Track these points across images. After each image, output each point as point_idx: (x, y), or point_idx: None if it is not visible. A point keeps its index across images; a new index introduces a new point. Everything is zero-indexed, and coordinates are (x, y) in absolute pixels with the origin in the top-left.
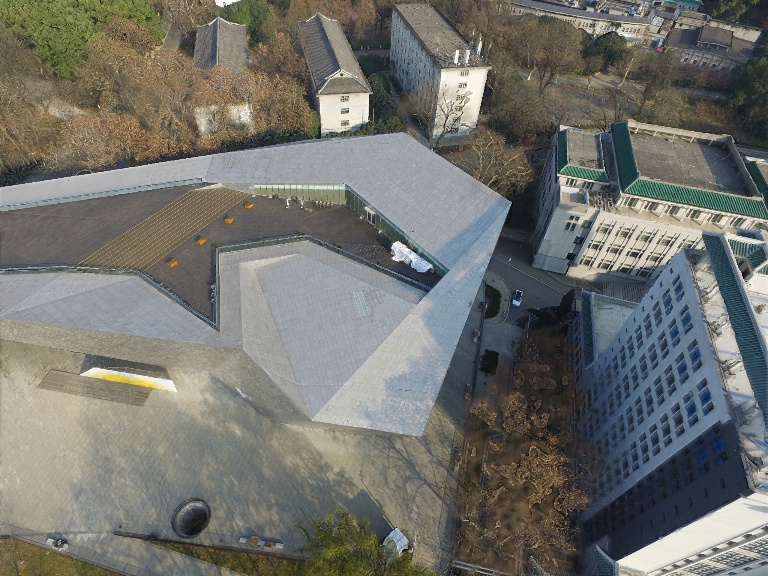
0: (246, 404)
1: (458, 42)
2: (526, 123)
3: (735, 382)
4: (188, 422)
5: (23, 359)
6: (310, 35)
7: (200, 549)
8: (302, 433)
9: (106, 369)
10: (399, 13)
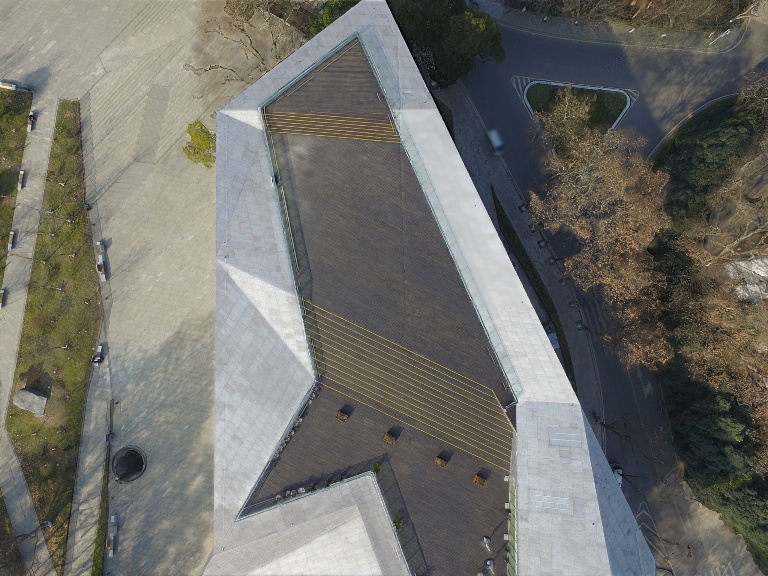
0: None
1: None
2: None
3: None
4: None
5: None
6: None
7: None
8: None
9: None
10: None
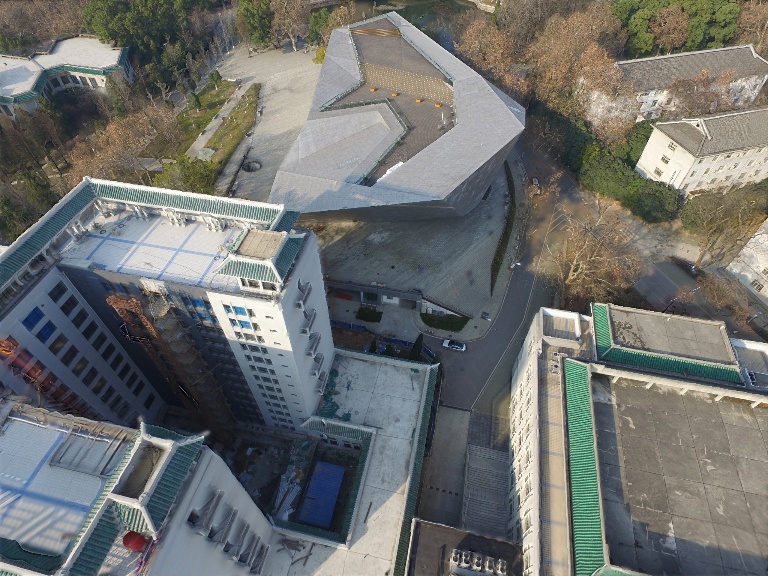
0: None
1: None
2: (715, 282)
3: (168, 225)
4: None
5: None
6: None
7: None
8: None
9: None
10: None
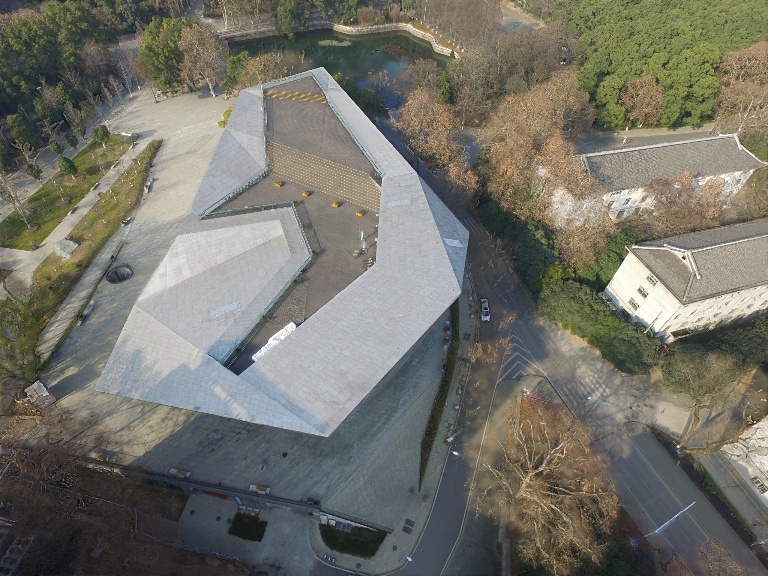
0: None
1: None
2: (726, 568)
3: None
4: None
5: None
6: None
7: None
8: None
9: None
10: None
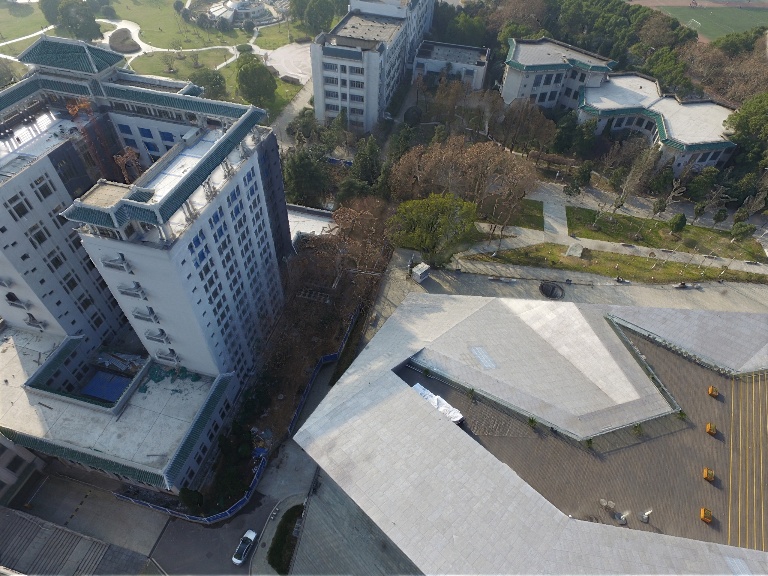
0: None
1: None
2: None
3: None
4: None
5: None
6: None
7: None
8: None
9: None
10: None
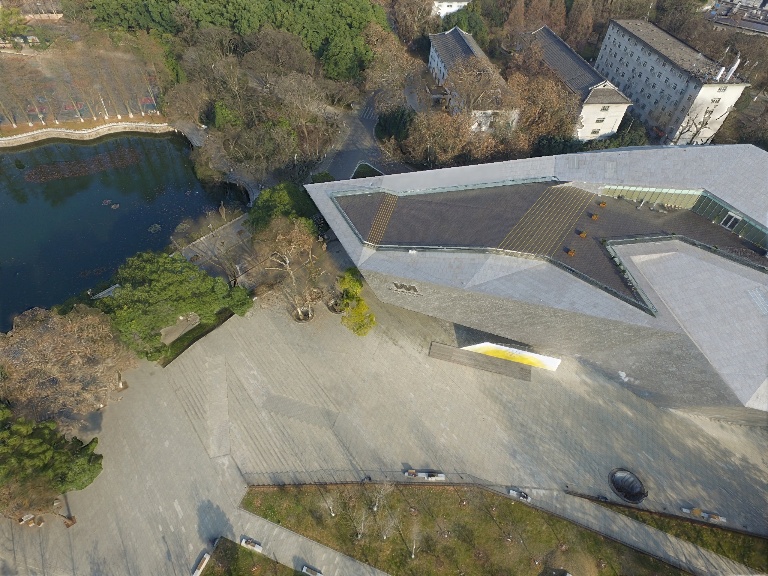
0: (623, 388)
1: (702, 59)
2: None
3: None
4: (579, 399)
5: (402, 330)
6: (544, 46)
7: (645, 514)
8: (689, 419)
9: (498, 344)
10: (624, 28)
